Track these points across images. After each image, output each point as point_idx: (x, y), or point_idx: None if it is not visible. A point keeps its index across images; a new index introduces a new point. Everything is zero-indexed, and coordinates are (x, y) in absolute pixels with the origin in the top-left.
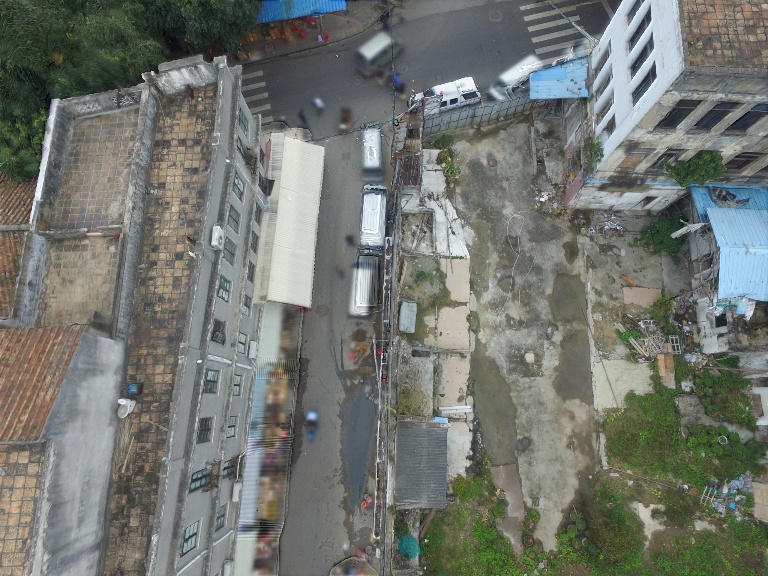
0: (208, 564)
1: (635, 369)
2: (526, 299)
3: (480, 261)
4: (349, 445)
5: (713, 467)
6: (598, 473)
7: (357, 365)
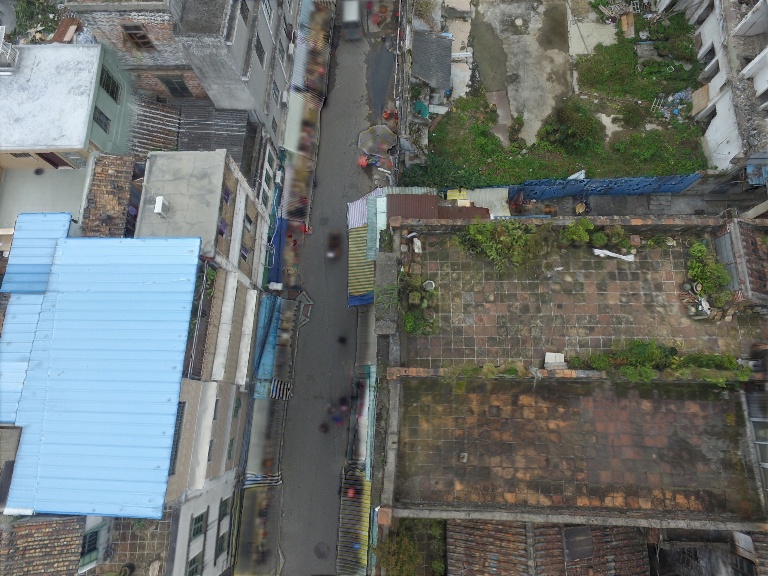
0: (276, 51)
1: (603, 28)
2: None
3: None
4: (373, 81)
5: (662, 86)
6: (571, 96)
7: (380, 28)
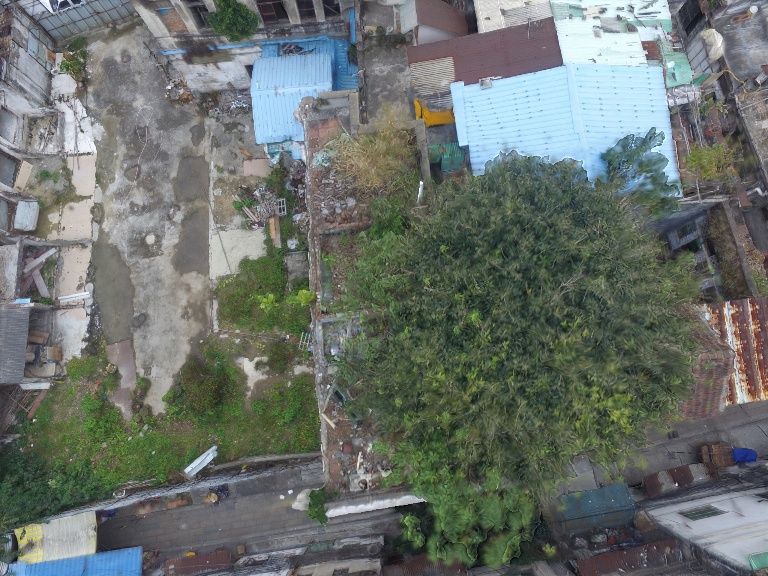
0: None
1: (250, 236)
2: (150, 185)
3: (108, 155)
4: None
5: None
6: (209, 337)
7: None
